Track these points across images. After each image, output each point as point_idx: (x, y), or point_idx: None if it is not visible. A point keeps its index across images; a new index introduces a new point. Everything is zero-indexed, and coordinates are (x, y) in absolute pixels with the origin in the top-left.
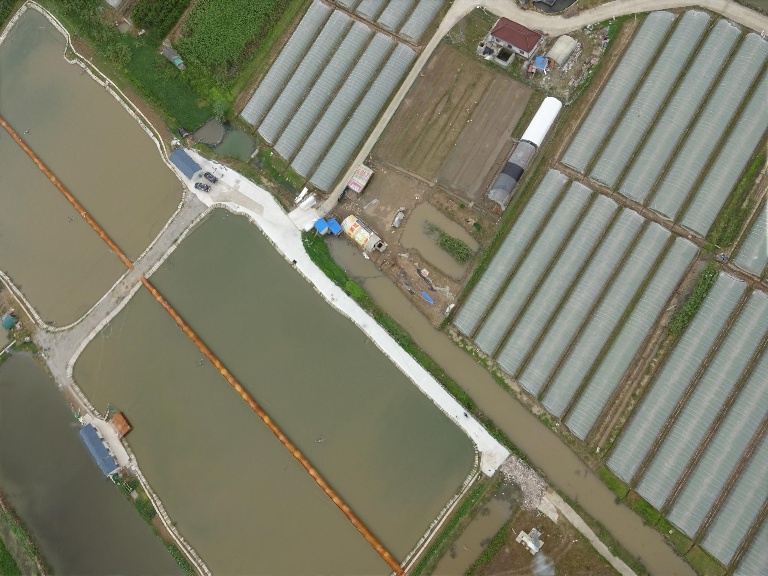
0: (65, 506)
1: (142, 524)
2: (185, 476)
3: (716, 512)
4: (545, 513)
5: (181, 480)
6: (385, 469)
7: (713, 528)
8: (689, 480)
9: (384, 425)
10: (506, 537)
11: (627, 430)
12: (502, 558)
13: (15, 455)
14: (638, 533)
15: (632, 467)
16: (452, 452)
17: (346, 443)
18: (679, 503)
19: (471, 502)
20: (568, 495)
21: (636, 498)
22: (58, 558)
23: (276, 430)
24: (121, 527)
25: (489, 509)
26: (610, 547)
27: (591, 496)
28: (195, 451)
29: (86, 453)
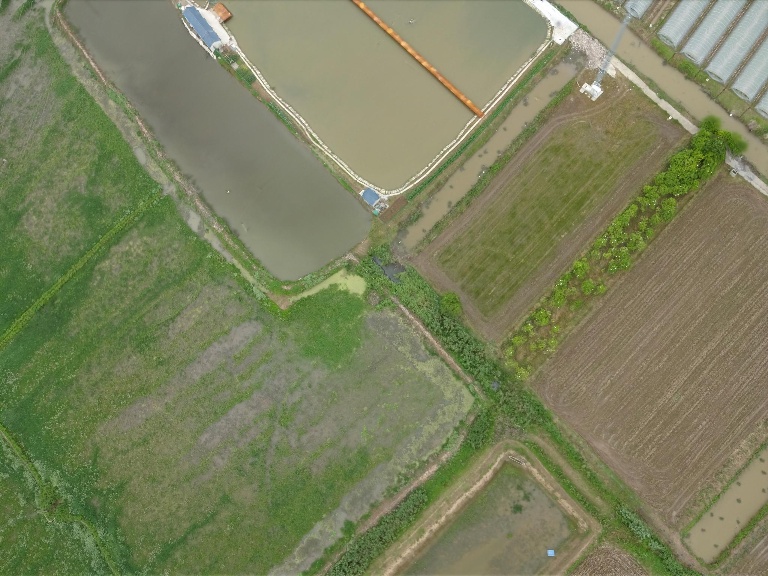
0: (165, 79)
1: (241, 90)
2: (283, 53)
3: (744, 66)
4: (605, 70)
5: (279, 56)
6: (469, 41)
7: (741, 75)
8: (724, 43)
9: (469, 9)
10: (572, 87)
11: (676, 9)
12: (568, 104)
13: (114, 40)
14: (680, 85)
15: (678, 36)
16: (528, 28)
17: (434, 23)
18: (716, 58)
19: (543, 63)
20: (624, 60)
21: (681, 57)
22: (158, 120)
23: (371, 13)
24: (221, 93)
25: (558, 70)
26: (658, 93)
27: (643, 60)
28: (293, 34)
29: (185, 38)
